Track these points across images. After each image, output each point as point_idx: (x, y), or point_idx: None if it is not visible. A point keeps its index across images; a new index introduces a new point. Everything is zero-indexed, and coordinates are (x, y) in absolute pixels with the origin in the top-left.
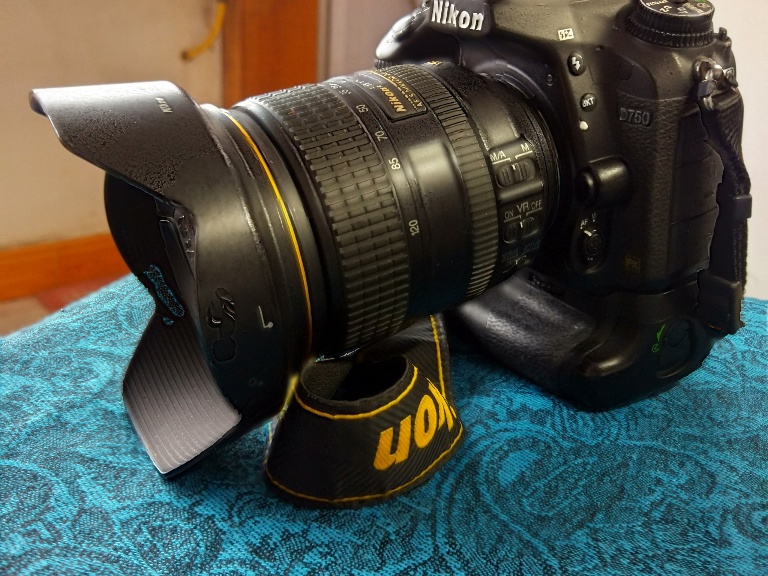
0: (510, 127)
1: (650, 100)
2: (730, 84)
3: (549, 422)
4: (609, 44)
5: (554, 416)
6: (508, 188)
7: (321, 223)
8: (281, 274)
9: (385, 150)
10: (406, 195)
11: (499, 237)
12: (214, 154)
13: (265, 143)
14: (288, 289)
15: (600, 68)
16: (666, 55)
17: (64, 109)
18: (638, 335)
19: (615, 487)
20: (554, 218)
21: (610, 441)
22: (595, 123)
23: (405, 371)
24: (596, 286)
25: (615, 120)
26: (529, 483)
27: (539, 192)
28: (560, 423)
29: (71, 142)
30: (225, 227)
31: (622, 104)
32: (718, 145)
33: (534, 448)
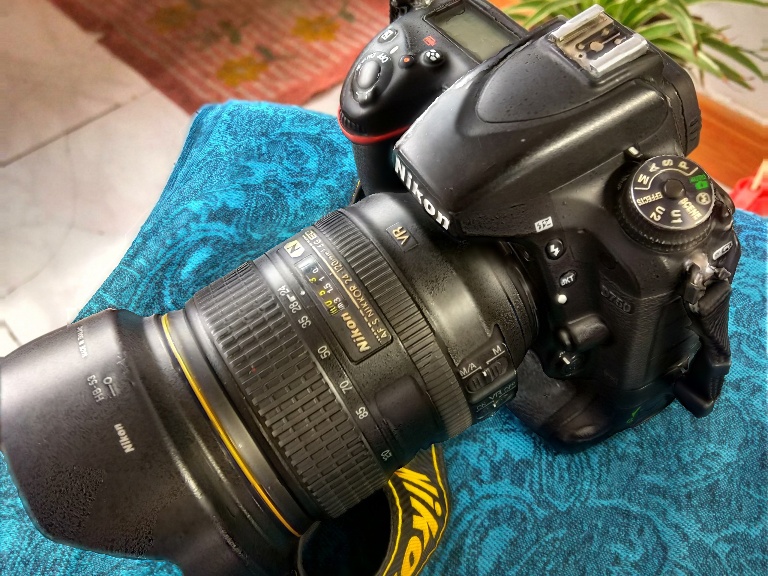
0: (481, 328)
1: (632, 297)
2: (722, 279)
3: (528, 480)
4: (593, 229)
5: (533, 469)
6: (479, 391)
7: (296, 489)
8: (266, 543)
9: (351, 402)
10: (376, 438)
11: (472, 418)
12: (184, 495)
13: (231, 418)
14: (274, 545)
15: (582, 248)
16: (653, 258)
17: (31, 479)
18: (614, 413)
19: (578, 570)
20: (534, 340)
21: (581, 503)
22: (575, 294)
23: (389, 544)
24: (576, 376)
25: (596, 291)
26: (504, 572)
27: (512, 380)
28: (538, 479)
29: (49, 533)
30: (208, 562)
31: (604, 283)
32: (701, 333)
33: (511, 522)
